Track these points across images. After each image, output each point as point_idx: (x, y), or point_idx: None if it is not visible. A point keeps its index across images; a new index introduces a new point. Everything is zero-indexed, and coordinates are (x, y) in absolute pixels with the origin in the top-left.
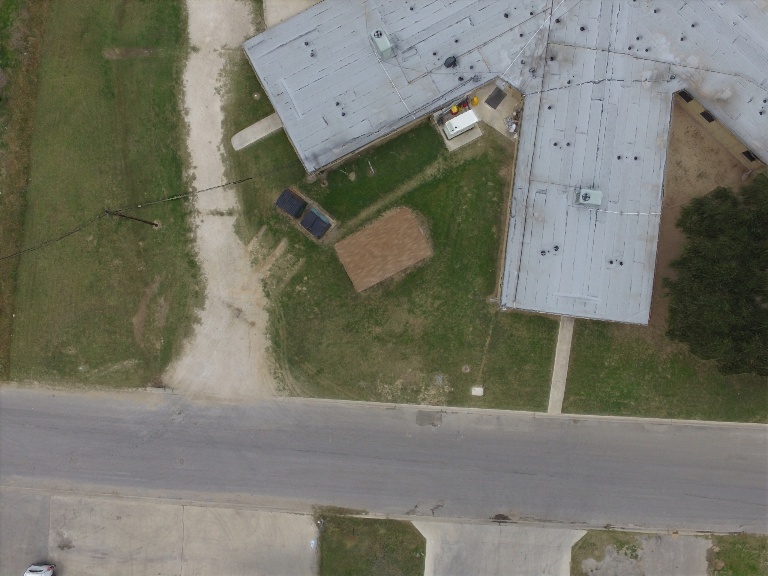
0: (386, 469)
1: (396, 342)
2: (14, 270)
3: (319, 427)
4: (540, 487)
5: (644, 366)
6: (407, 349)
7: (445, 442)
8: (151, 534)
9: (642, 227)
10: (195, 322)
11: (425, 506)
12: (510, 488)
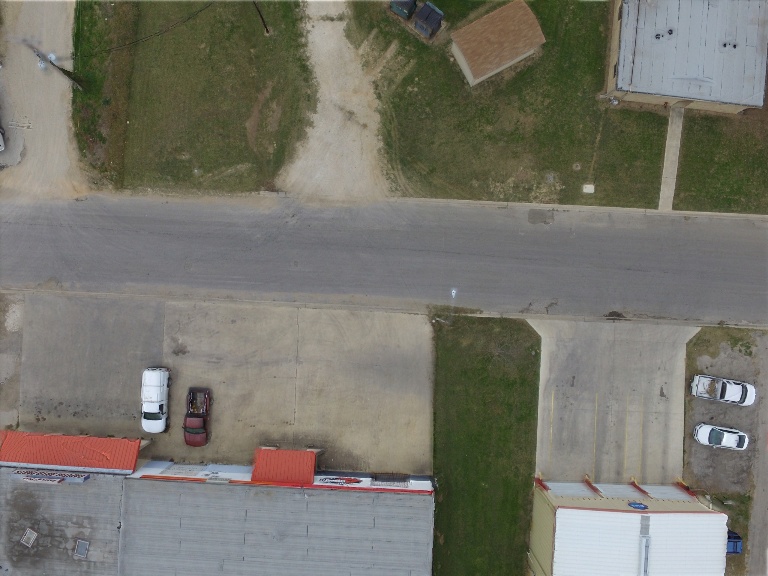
0: (500, 267)
1: (507, 140)
2: (128, 78)
3: (432, 226)
4: (653, 284)
5: (753, 162)
6: (518, 147)
7: (558, 239)
8: (266, 337)
9: (753, 12)
10: (307, 125)
11: (539, 304)
12: (623, 285)
